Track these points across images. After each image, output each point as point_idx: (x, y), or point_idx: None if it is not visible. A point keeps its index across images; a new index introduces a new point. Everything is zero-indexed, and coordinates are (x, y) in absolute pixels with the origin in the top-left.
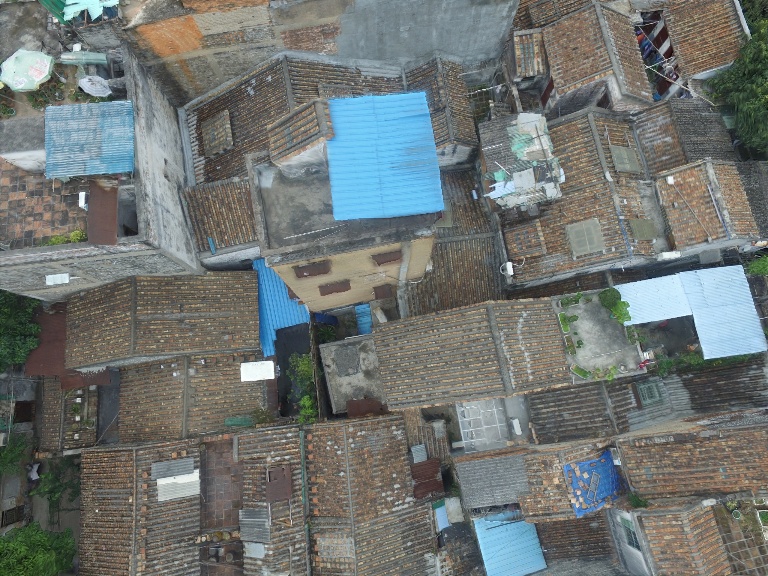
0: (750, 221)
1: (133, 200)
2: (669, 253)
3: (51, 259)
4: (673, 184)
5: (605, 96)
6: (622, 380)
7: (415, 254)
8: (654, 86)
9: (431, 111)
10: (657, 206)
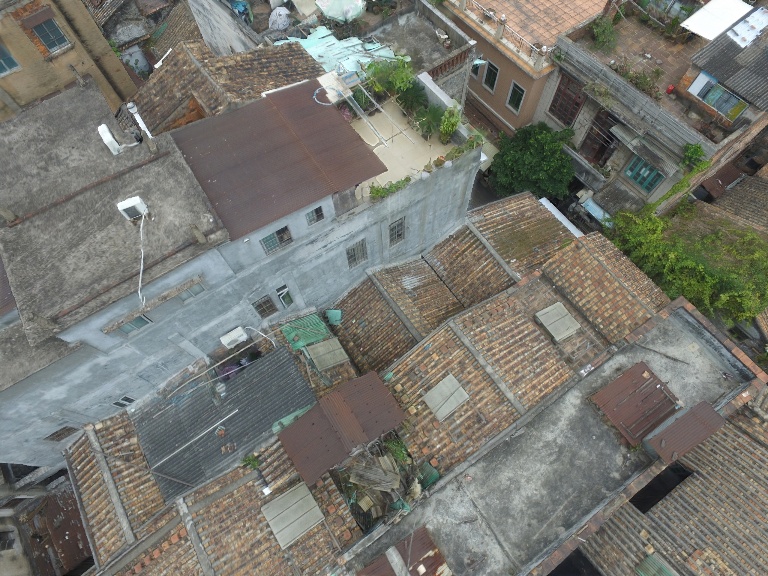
0: None
1: None
2: None
3: None
4: None
5: None
6: None
7: None
8: None
9: None
10: None
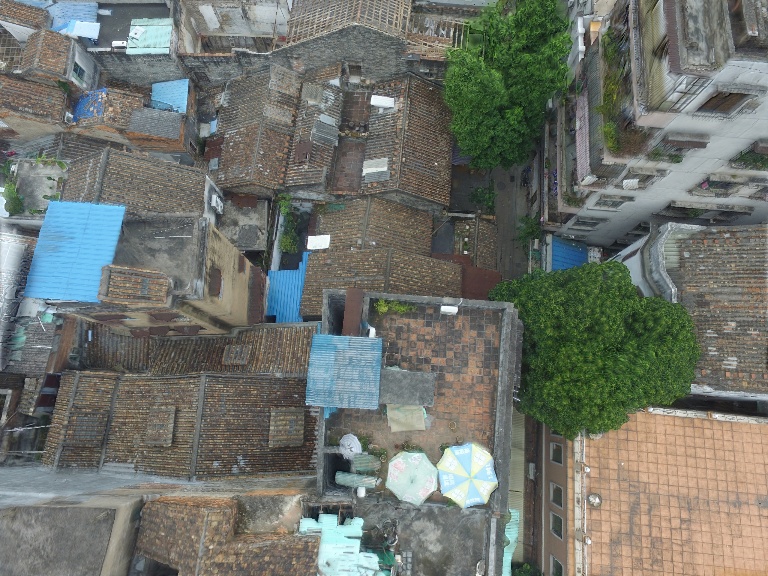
0: None
1: None
2: None
3: None
4: None
5: None
6: None
7: None
8: None
9: None
10: None
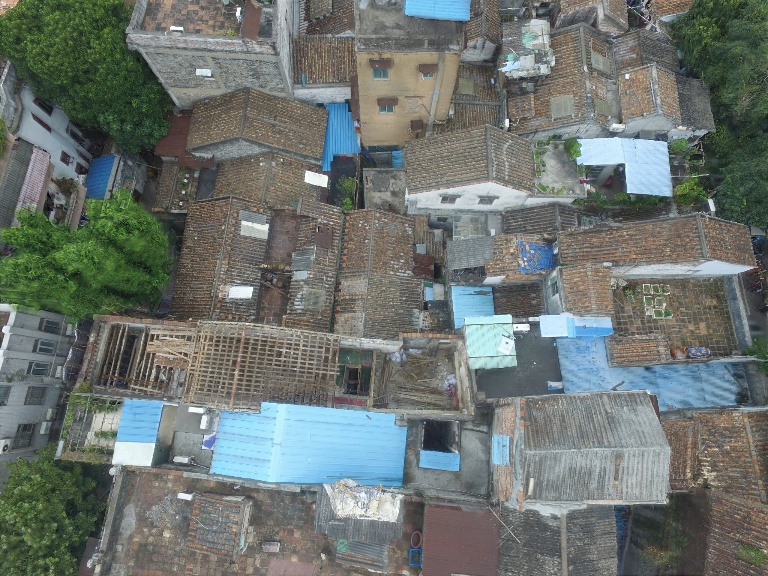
0: (677, 111)
1: (265, 26)
2: (618, 124)
3: (209, 49)
4: (628, 79)
5: (595, 20)
6: (571, 209)
7: (446, 77)
8: (636, 29)
9: (472, 15)
10: (617, 97)
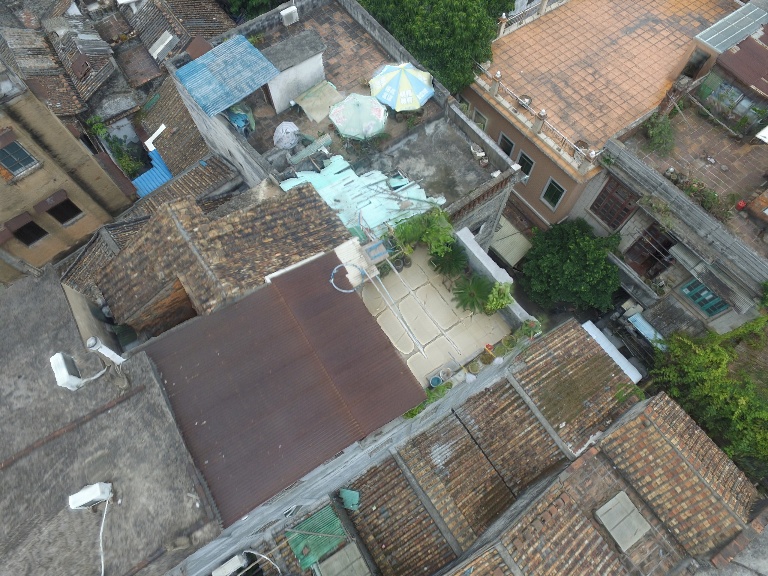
0: None
1: None
2: None
3: None
4: None
5: None
6: None
7: None
8: None
9: None
10: None
